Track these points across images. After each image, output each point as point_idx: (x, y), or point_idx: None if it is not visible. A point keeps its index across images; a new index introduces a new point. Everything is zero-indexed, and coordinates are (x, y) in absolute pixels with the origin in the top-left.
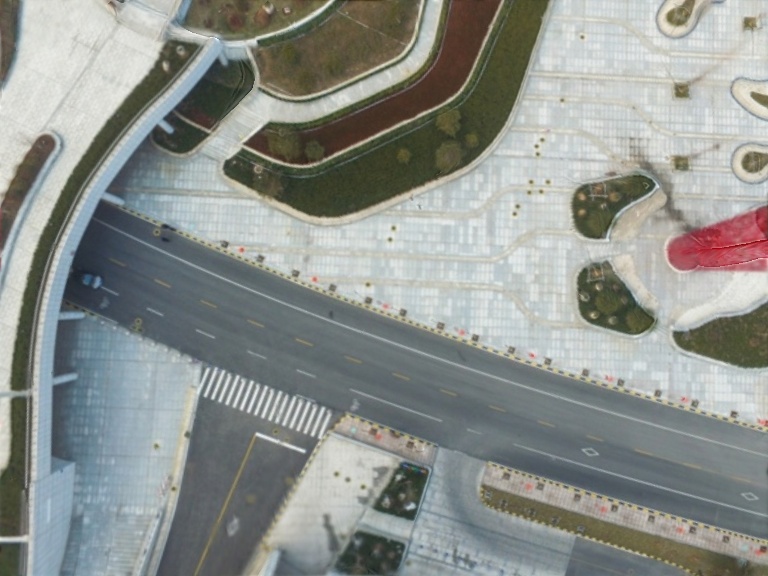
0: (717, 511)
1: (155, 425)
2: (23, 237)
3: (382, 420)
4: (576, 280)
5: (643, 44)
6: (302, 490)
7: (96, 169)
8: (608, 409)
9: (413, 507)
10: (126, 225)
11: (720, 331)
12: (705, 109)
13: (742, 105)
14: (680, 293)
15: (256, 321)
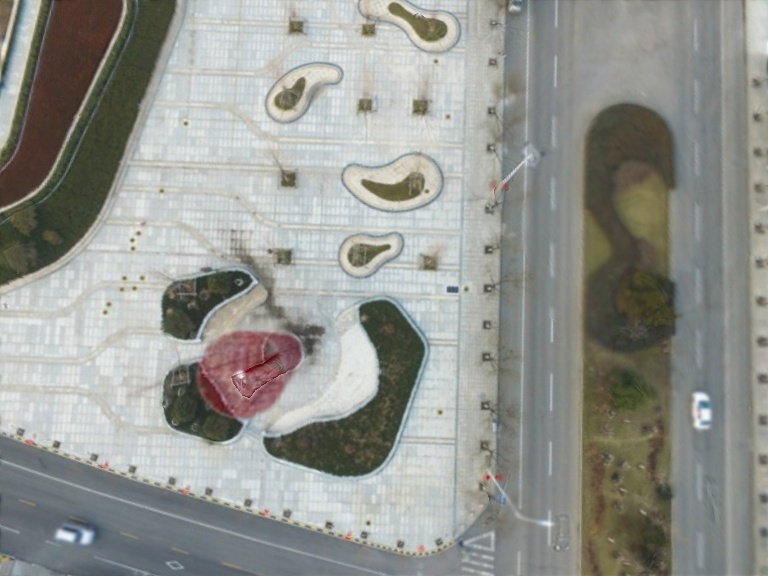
0: None
1: None
2: None
3: None
4: (163, 383)
5: (250, 130)
6: None
7: None
8: (195, 519)
9: None
10: None
11: (314, 437)
12: (313, 198)
13: (353, 193)
14: (278, 395)
15: None
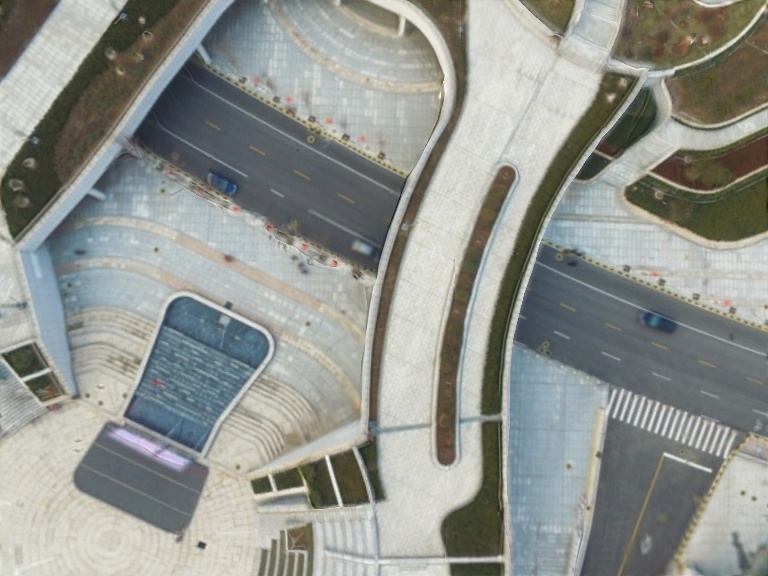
0: None
1: (567, 446)
2: (489, 266)
3: None
4: None
5: None
6: (711, 509)
7: (553, 199)
8: None
9: None
10: None
11: None
12: None
13: None
14: None
15: (660, 343)
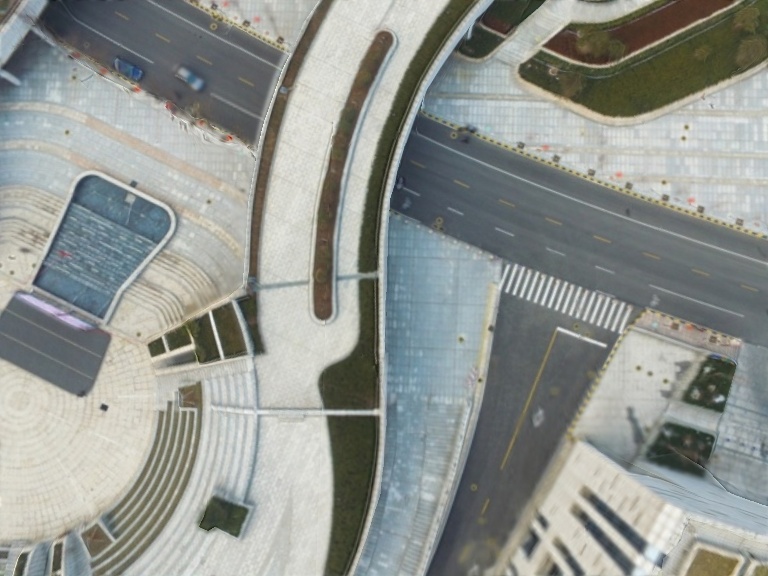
0: None
1: (459, 319)
2: (367, 128)
3: (683, 315)
4: None
5: None
6: (605, 383)
7: (431, 63)
8: None
9: (722, 399)
10: (425, 129)
11: None
12: None
13: None
14: None
15: (554, 219)
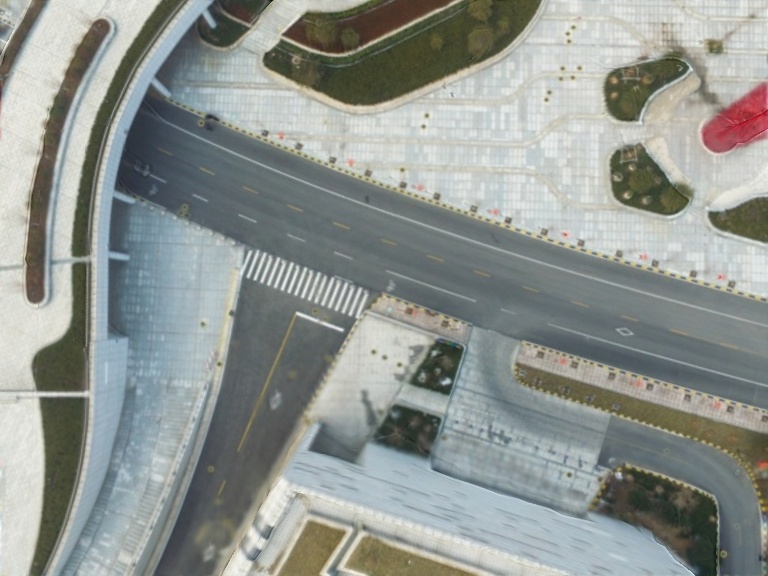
0: (755, 391)
1: (201, 304)
2: (81, 114)
3: (417, 300)
4: (609, 162)
5: None
6: (341, 367)
7: (147, 50)
8: (642, 290)
9: (448, 382)
10: (173, 117)
11: (757, 211)
12: None
13: None
14: (715, 175)
15: (295, 206)
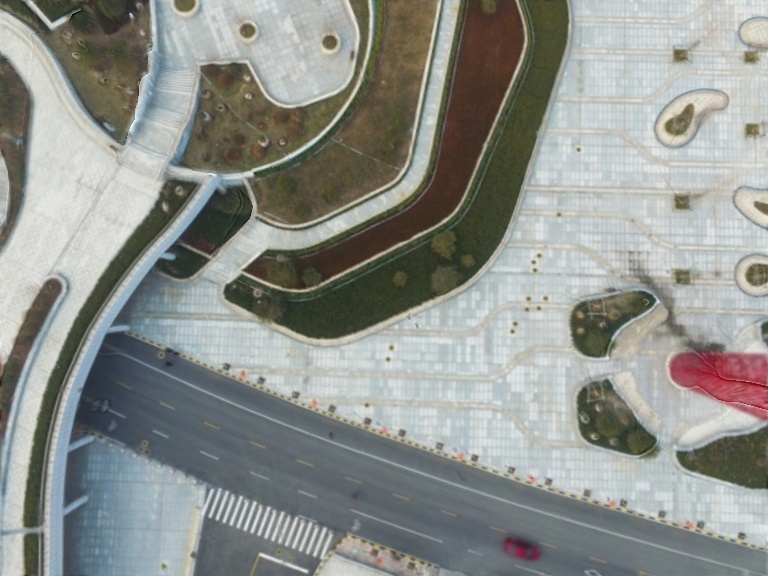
0: None
1: (162, 545)
2: (33, 379)
3: (383, 541)
4: (576, 399)
5: (641, 155)
6: None
7: (100, 311)
8: (611, 530)
9: None
10: (132, 349)
11: (725, 451)
12: (707, 220)
13: (745, 215)
14: (683, 410)
15: (258, 442)
